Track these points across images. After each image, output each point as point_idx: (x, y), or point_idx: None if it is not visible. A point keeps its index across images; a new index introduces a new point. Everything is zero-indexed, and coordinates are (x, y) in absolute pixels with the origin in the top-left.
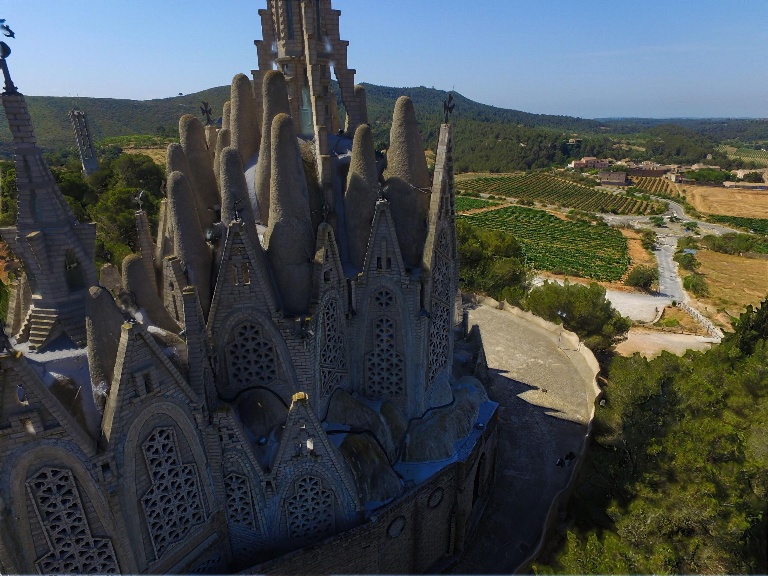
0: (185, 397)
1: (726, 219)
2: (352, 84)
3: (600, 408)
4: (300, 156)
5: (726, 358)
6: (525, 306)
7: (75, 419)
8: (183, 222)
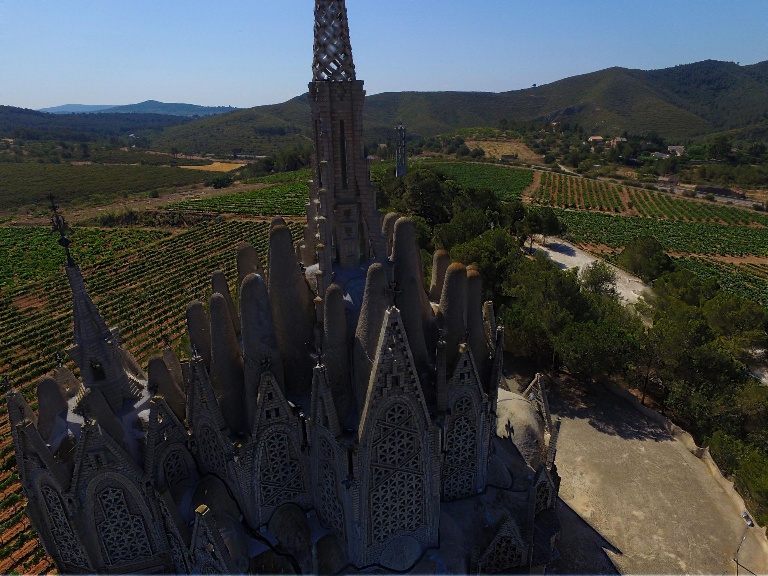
0: None
1: None
2: (377, 226)
3: None
4: (265, 309)
5: None
6: (734, 470)
7: (66, 464)
8: (192, 338)
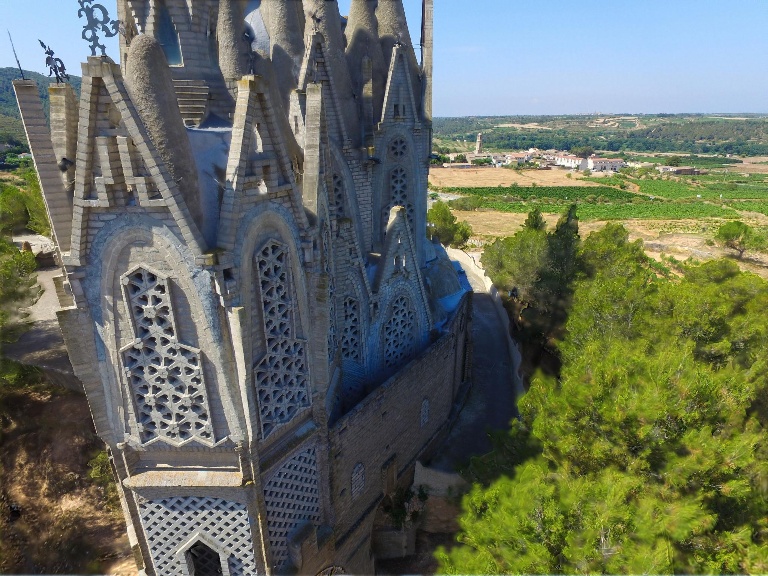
0: (327, 198)
1: (454, 189)
2: None
3: (494, 276)
4: None
5: None
6: None
7: None
8: (240, 38)
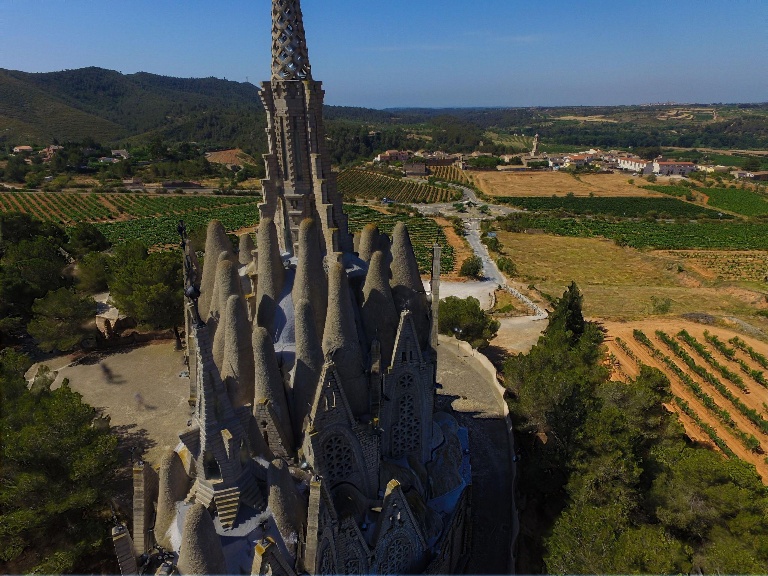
0: (330, 518)
1: (506, 200)
2: None
3: (511, 404)
4: None
5: (566, 339)
6: None
7: None
8: (271, 369)
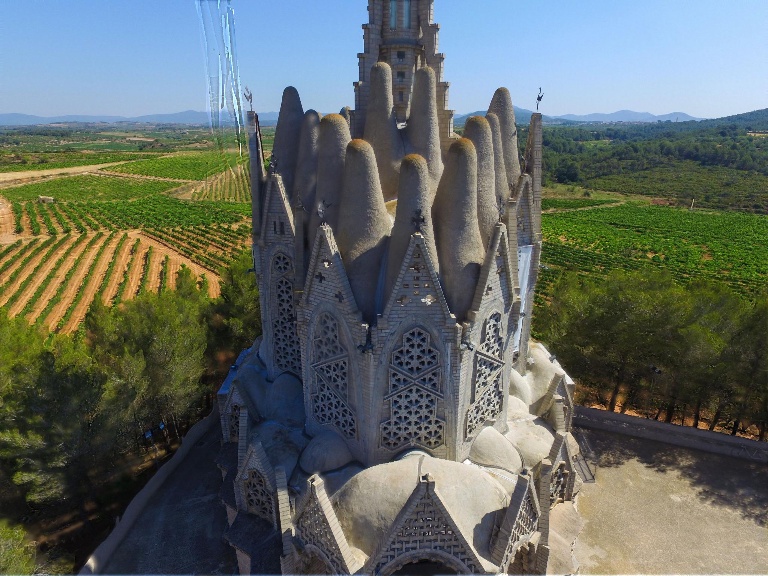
0: None
1: None
2: None
3: None
4: None
5: None
6: None
7: None
8: None
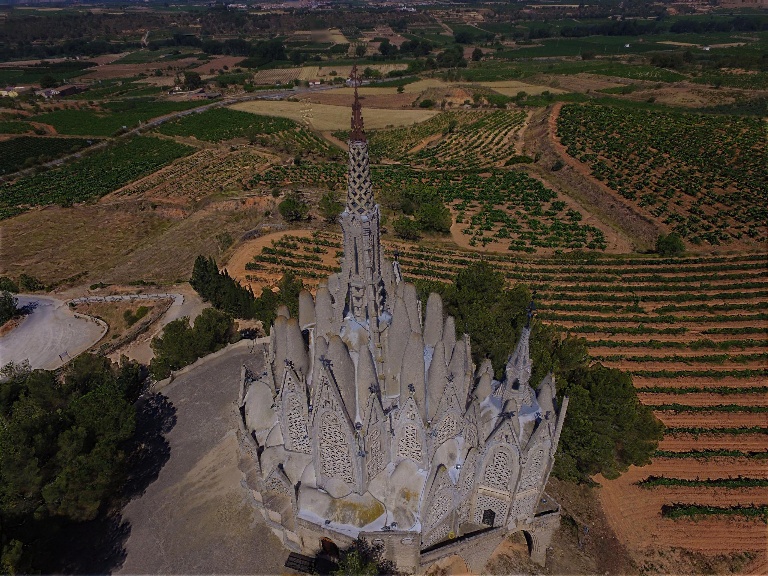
0: None
1: None
2: None
3: None
4: None
5: None
6: (184, 361)
7: None
8: None
